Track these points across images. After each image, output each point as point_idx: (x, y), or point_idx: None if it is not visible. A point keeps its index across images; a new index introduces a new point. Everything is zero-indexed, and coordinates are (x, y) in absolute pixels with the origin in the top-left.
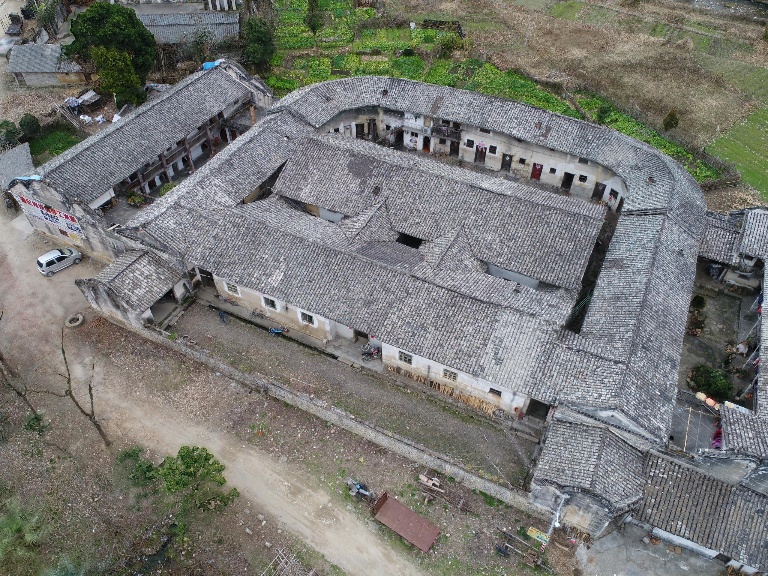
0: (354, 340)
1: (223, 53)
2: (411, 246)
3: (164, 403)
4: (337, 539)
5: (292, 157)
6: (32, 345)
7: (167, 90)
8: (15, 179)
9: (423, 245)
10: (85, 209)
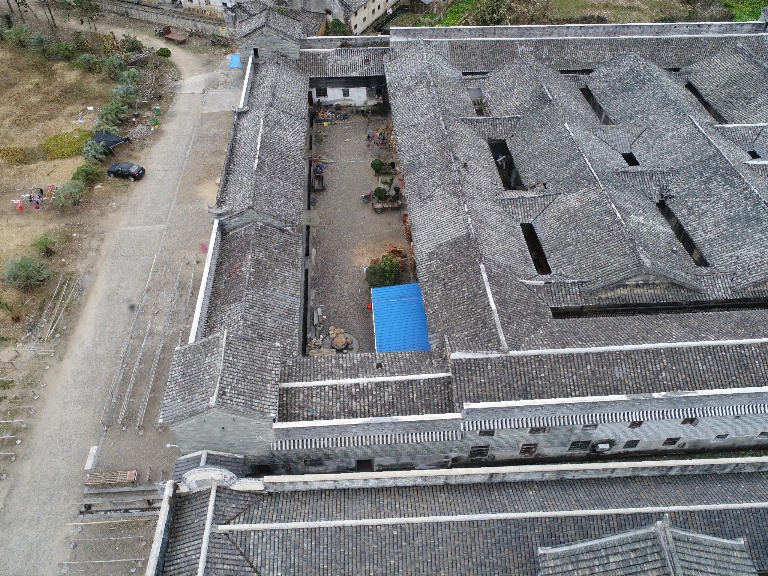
0: (172, 2)
1: None
2: None
3: None
4: (148, 43)
5: None
6: (20, 7)
7: None
8: None
9: None
10: None
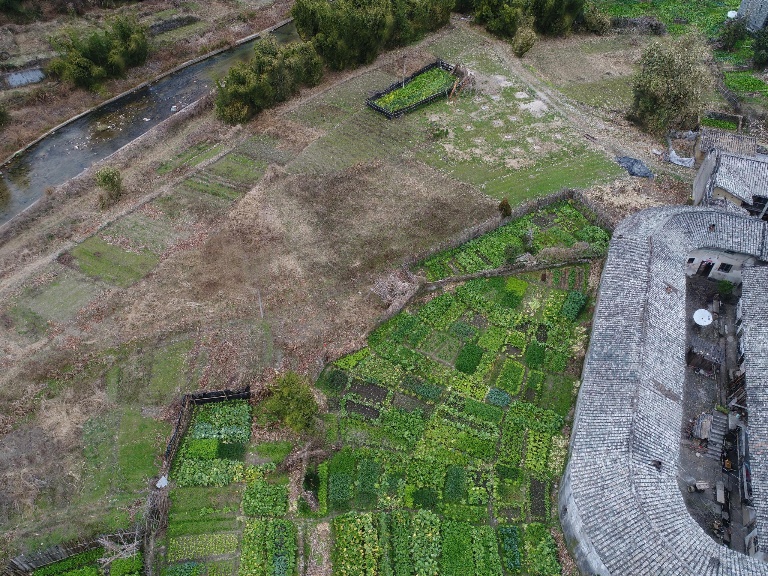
0: None
1: None
2: None
3: None
4: None
5: None
6: None
7: None
8: None
9: None
10: None
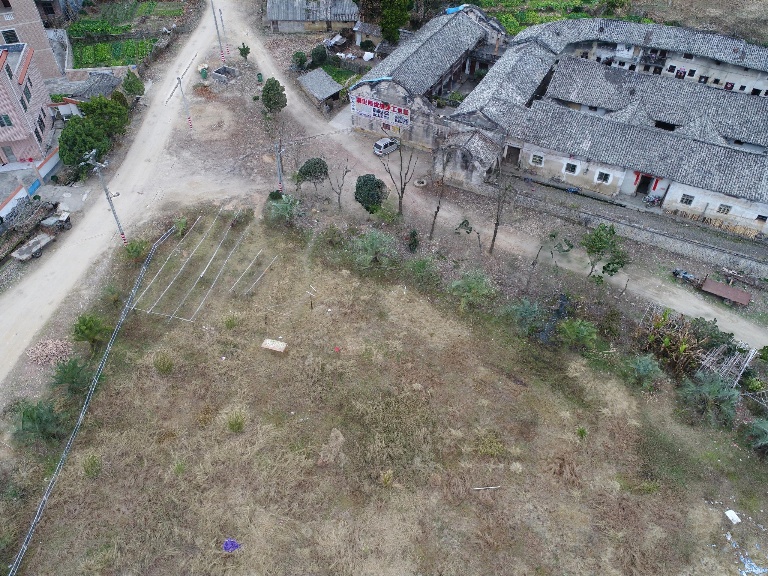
0: (635, 194)
1: (434, 7)
2: (668, 130)
3: (515, 230)
4: (679, 302)
5: (557, 70)
6: None
7: (423, 29)
8: (362, 82)
9: (677, 129)
10: (426, 101)
